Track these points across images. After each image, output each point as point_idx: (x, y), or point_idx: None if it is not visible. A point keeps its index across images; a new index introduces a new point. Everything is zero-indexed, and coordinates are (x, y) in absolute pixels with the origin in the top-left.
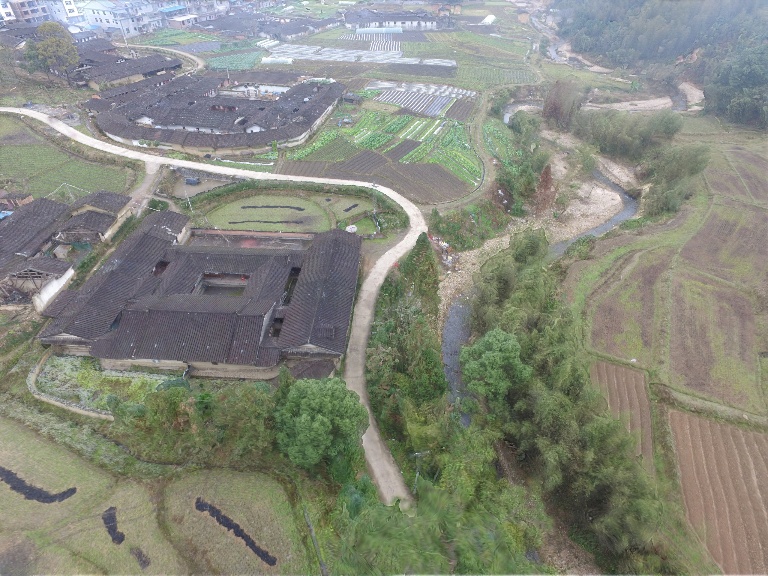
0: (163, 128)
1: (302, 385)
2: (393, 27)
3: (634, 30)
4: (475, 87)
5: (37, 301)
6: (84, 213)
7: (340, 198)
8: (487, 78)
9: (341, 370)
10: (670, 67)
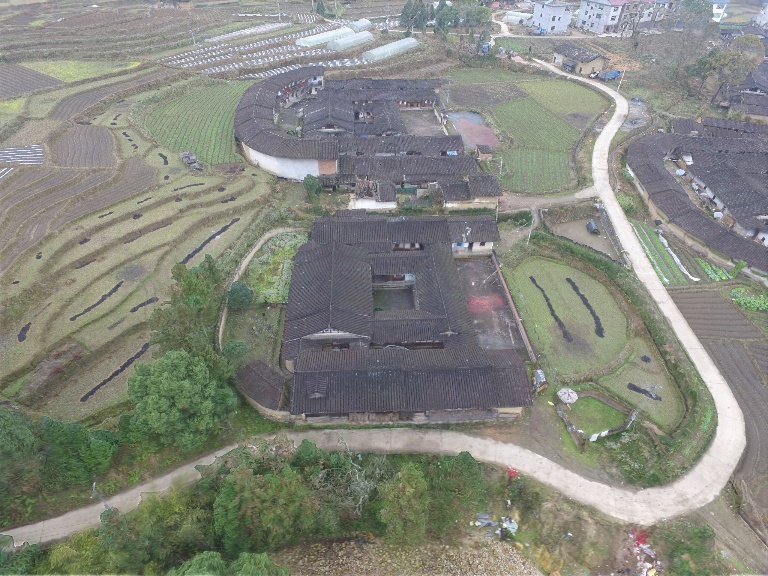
0: None
1: (174, 354)
2: None
3: None
4: None
5: (352, 203)
6: (464, 181)
7: (662, 373)
8: None
9: (297, 428)
10: None
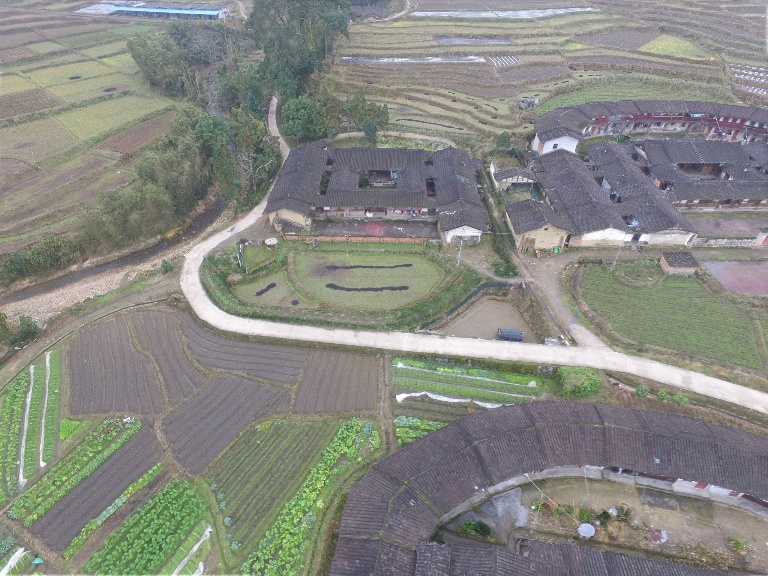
0: None
1: (305, 100)
2: None
3: None
4: None
5: None
6: None
7: None
8: None
9: None
10: None
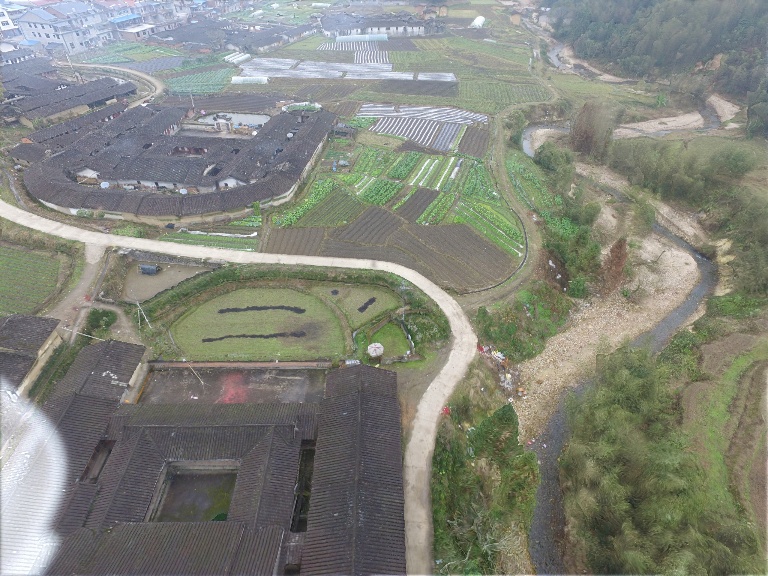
0: (112, 184)
1: None
2: (377, 34)
3: (648, 34)
4: (484, 108)
5: None
6: None
7: (350, 288)
8: (495, 96)
9: None
10: (697, 78)
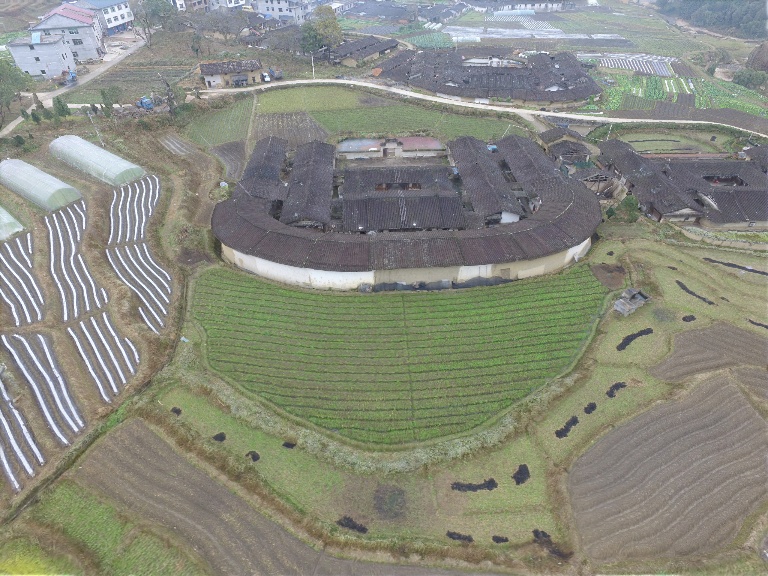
0: None
1: None
2: (524, 9)
3: None
4: (668, 54)
5: None
6: (562, 142)
7: (694, 133)
8: (667, 47)
9: None
10: None
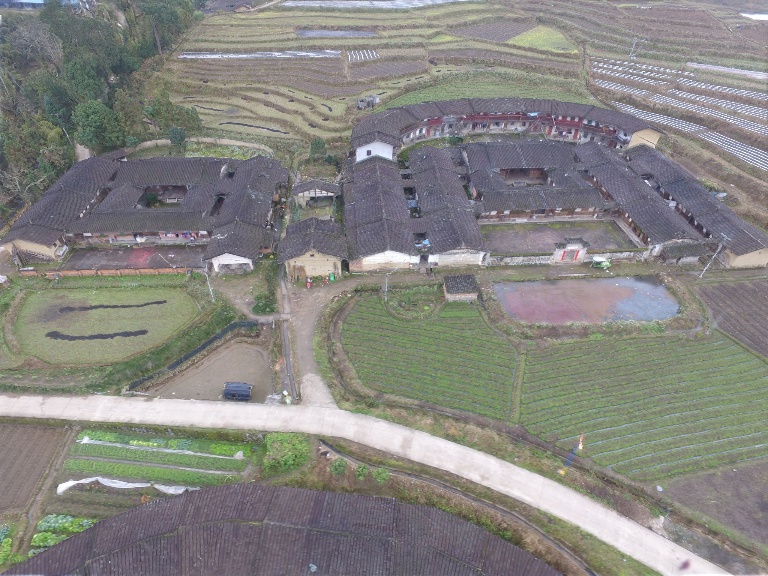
0: None
1: (96, 104)
2: None
3: None
4: None
5: None
6: None
7: None
8: None
9: None
10: None
